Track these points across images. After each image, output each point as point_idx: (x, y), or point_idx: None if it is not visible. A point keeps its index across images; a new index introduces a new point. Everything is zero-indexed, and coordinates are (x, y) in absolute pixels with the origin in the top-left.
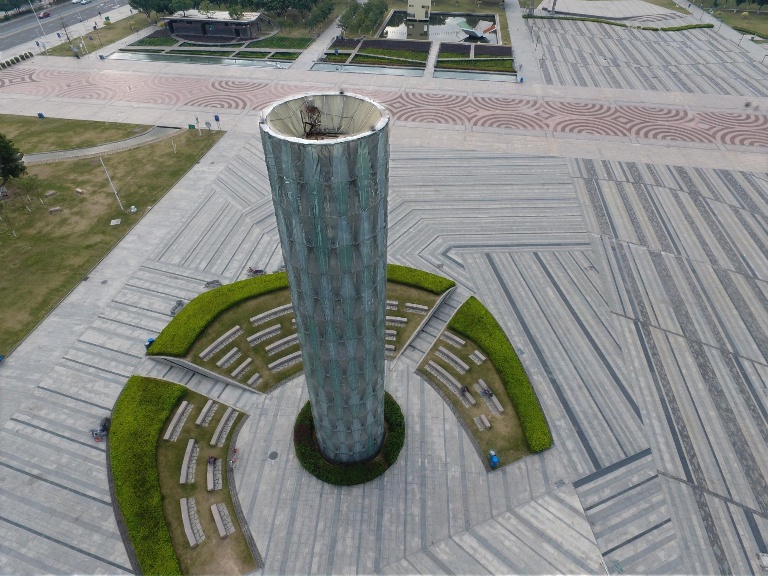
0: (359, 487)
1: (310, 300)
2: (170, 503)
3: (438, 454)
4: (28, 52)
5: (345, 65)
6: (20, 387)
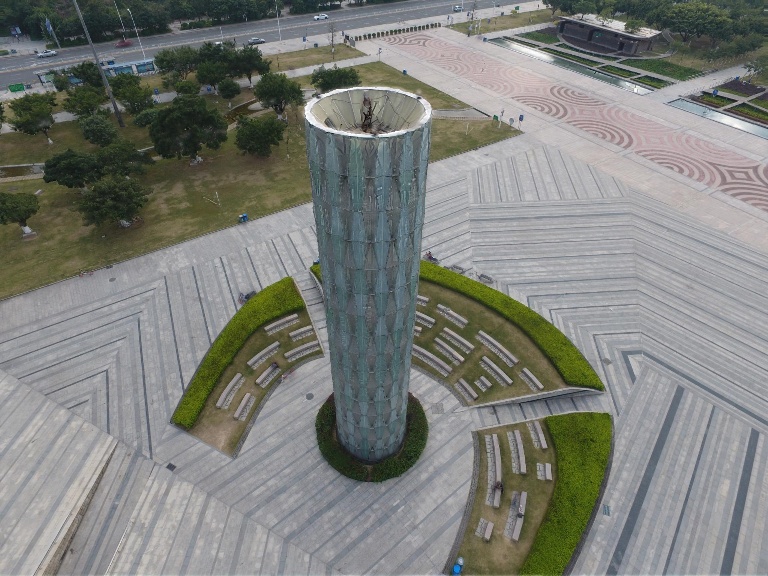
0: (335, 473)
1: None
2: (232, 370)
3: (418, 513)
4: (439, 23)
5: (715, 110)
6: (239, 242)
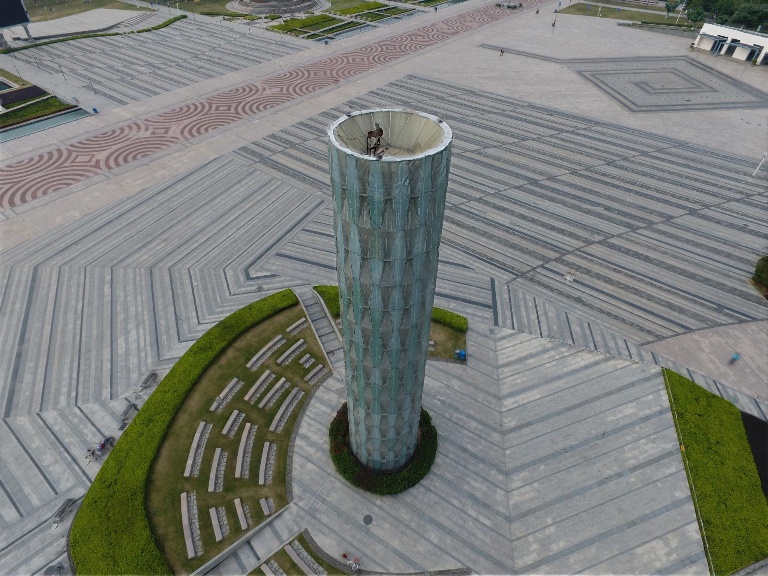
0: (437, 455)
1: (416, 308)
2: None
3: (437, 386)
4: None
5: None
6: None
